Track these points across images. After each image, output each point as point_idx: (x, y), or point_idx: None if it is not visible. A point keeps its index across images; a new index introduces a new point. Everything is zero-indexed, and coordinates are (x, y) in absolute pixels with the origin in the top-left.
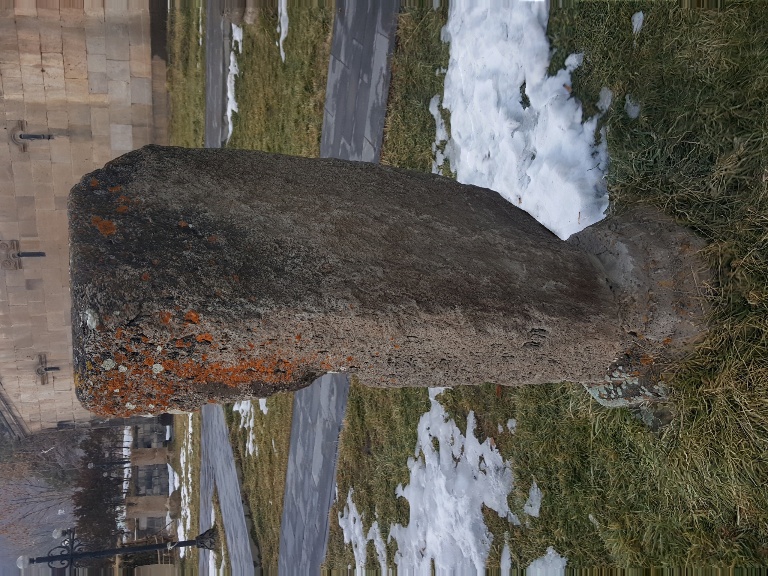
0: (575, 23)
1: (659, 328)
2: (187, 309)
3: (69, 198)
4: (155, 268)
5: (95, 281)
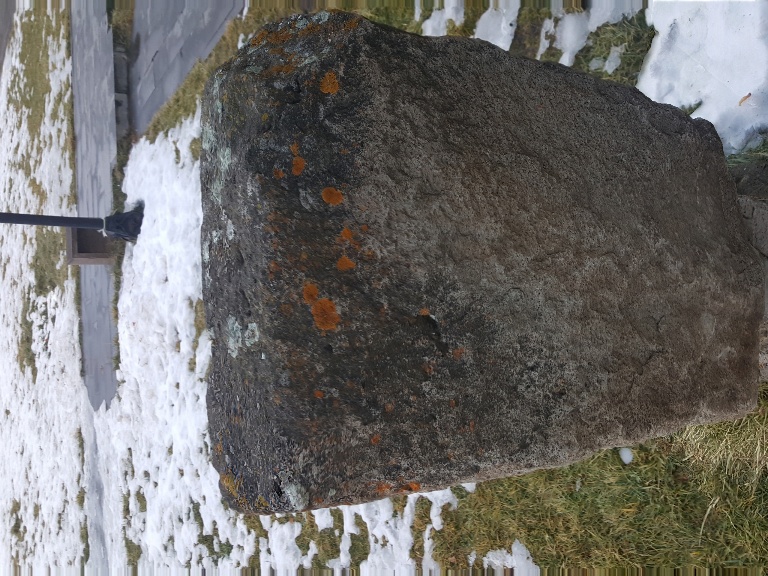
0: None
1: (765, 361)
2: (411, 479)
3: (261, 202)
4: (389, 422)
5: (314, 446)
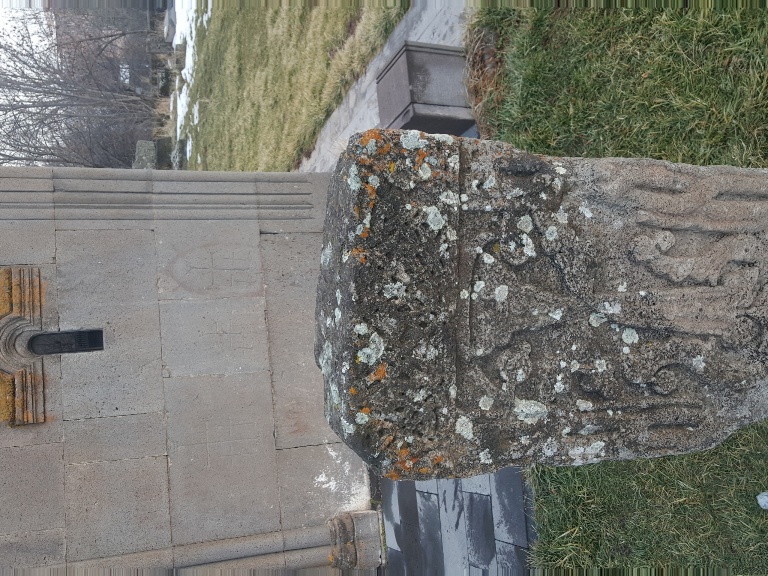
0: None
1: None
2: None
3: None
4: None
5: None
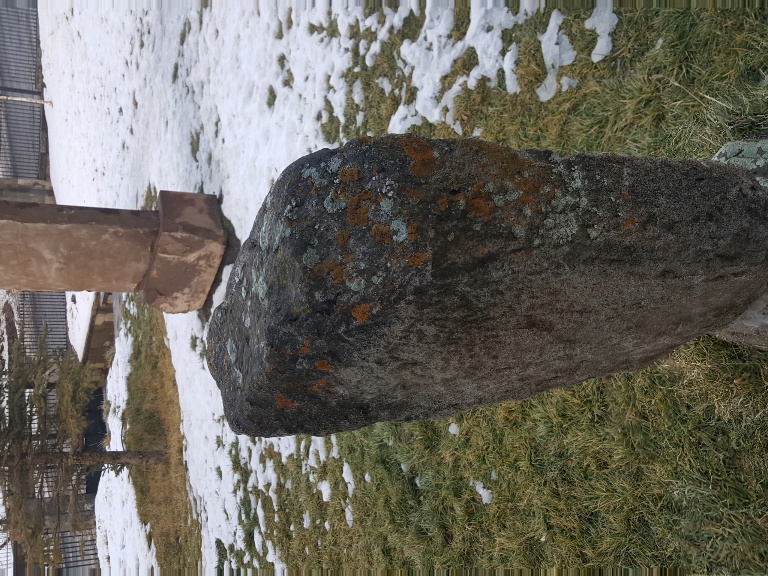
0: None
1: None
2: None
3: (265, 360)
4: None
5: None
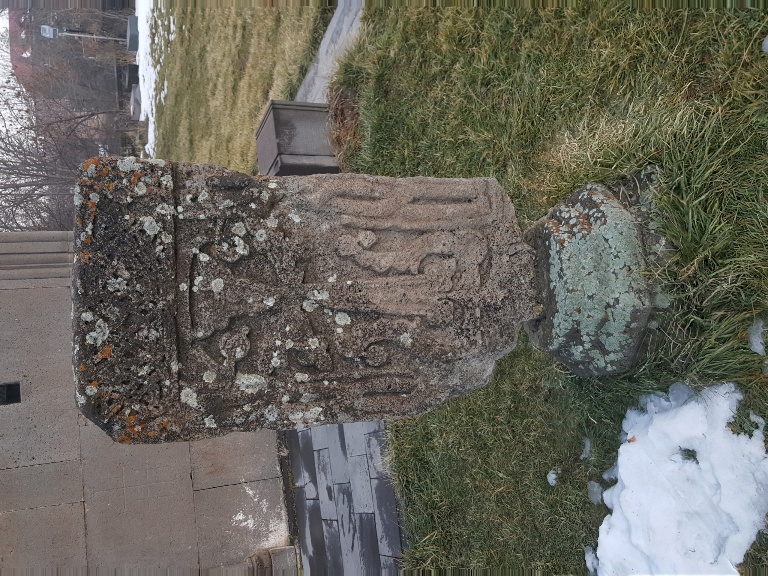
0: (573, 573)
1: None
2: None
3: None
4: None
5: None
